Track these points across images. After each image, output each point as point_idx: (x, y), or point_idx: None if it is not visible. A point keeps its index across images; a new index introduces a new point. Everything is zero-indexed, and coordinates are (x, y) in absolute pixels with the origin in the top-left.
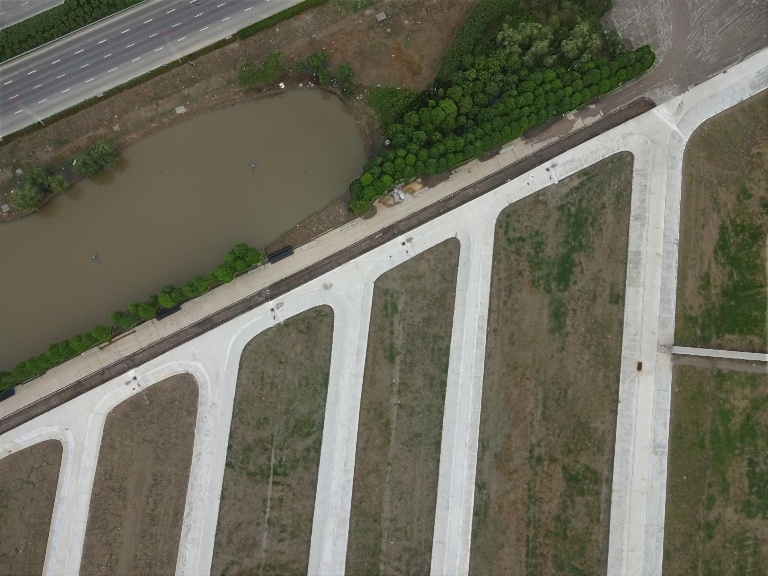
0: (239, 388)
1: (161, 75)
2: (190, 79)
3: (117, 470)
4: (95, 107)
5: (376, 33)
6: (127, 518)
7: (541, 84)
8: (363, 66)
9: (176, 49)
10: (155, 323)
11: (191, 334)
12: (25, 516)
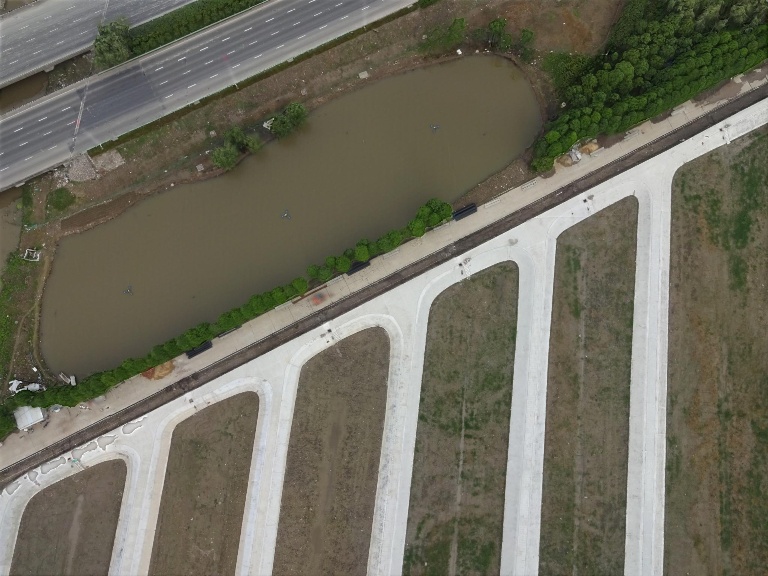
0: (429, 342)
1: (347, 41)
2: (373, 46)
3: (312, 422)
4: (285, 72)
5: (547, 2)
6: (323, 470)
7: (717, 45)
8: (536, 33)
9: (361, 17)
10: (345, 278)
11: (381, 289)
12: (224, 467)
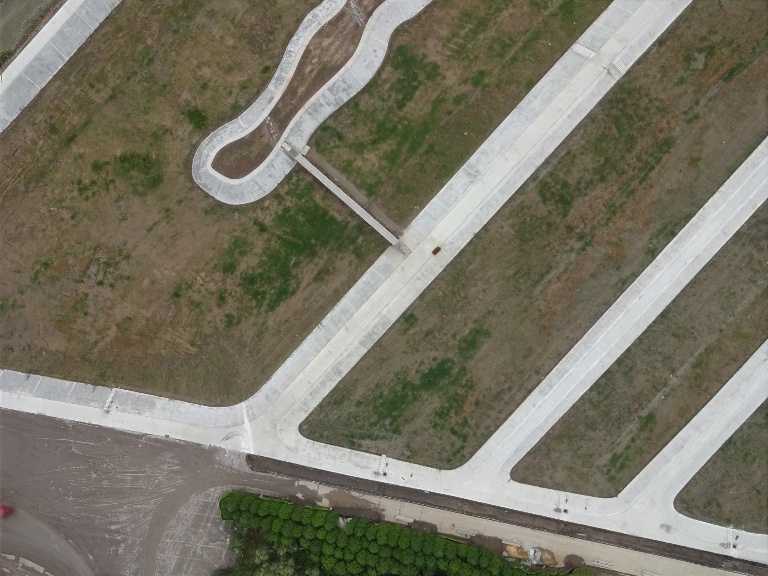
0: None
1: None
2: None
3: None
4: None
5: None
6: None
7: (341, 560)
8: None
9: None
10: None
11: None
12: None
